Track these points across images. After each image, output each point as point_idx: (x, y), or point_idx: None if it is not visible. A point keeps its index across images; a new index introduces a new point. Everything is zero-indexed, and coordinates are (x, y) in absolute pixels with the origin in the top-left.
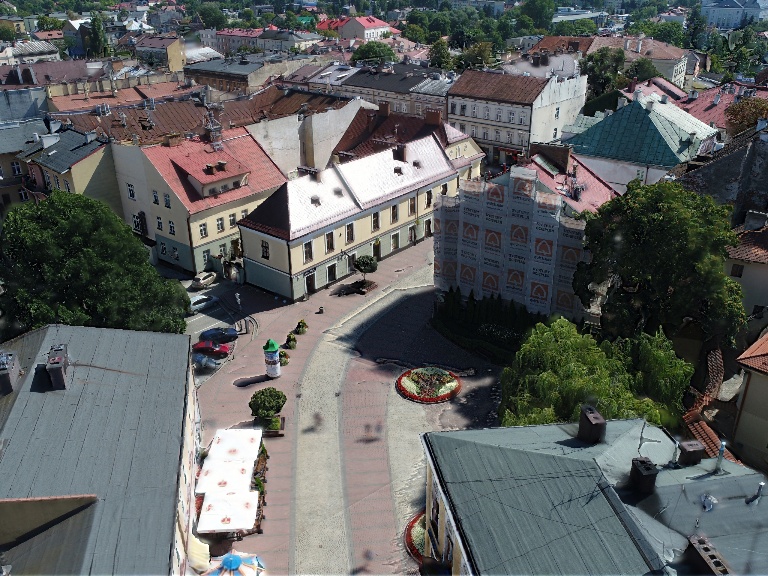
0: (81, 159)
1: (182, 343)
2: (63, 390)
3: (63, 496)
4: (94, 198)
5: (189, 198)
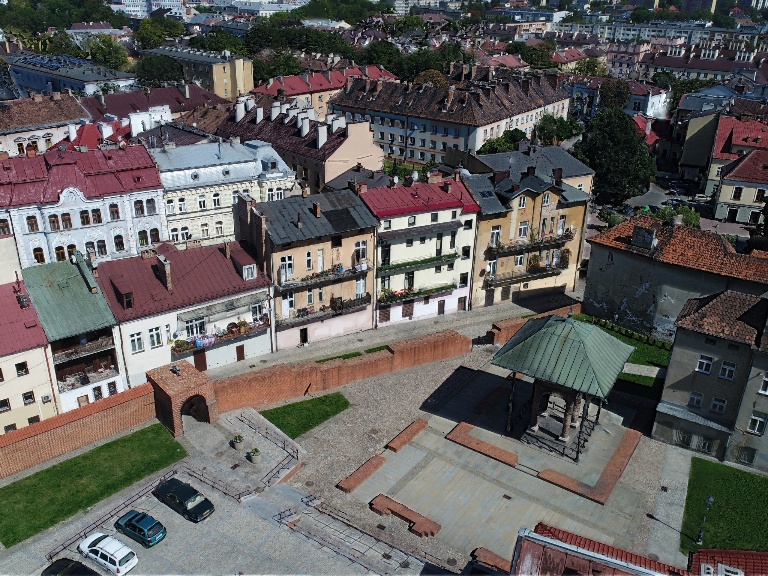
0: (699, 117)
1: (588, 171)
2: (529, 156)
3: (489, 166)
4: (696, 141)
5: (722, 150)
